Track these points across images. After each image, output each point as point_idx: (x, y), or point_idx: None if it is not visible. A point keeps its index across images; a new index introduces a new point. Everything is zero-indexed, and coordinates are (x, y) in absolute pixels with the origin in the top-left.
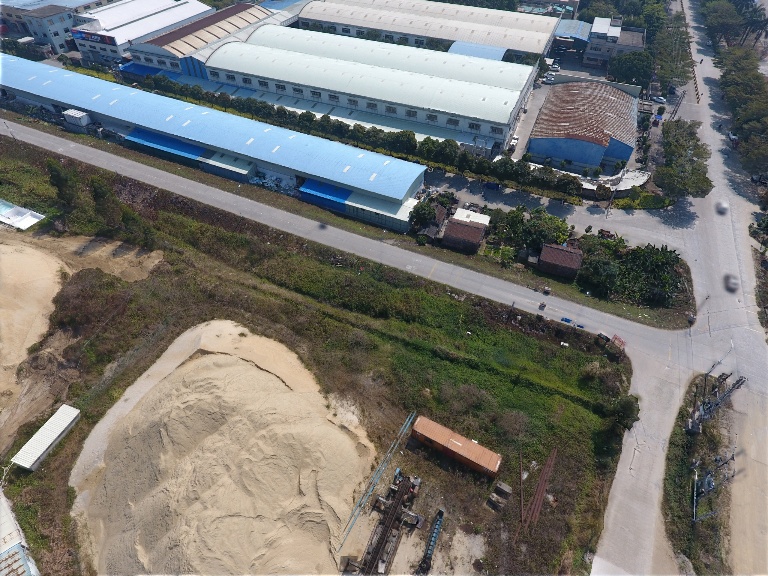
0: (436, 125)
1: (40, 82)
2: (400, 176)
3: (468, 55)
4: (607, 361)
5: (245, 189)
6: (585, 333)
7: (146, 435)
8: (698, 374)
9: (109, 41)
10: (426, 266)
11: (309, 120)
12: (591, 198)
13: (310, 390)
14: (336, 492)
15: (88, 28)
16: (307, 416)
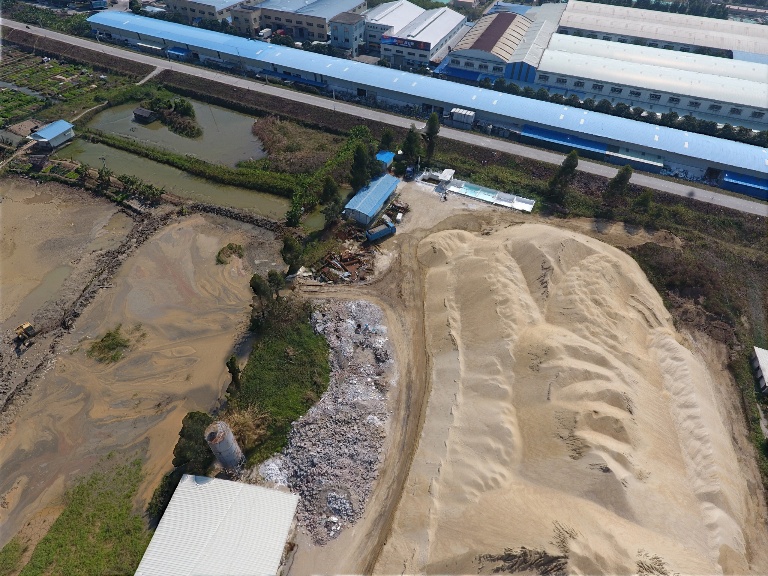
0: None
1: (408, 84)
2: None
3: (763, 63)
4: None
5: (674, 179)
6: None
7: None
8: None
9: (423, 46)
10: None
11: (674, 120)
12: None
13: None
14: None
15: (388, 34)
16: None
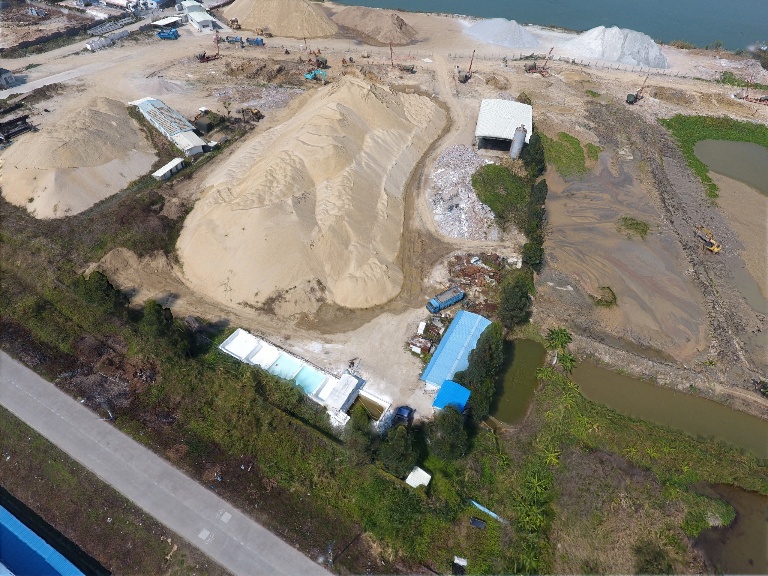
0: None
1: None
2: None
3: None
4: None
5: None
6: None
7: (96, 134)
8: None
9: None
10: None
11: None
12: None
13: (5, 173)
14: None
15: None
16: None
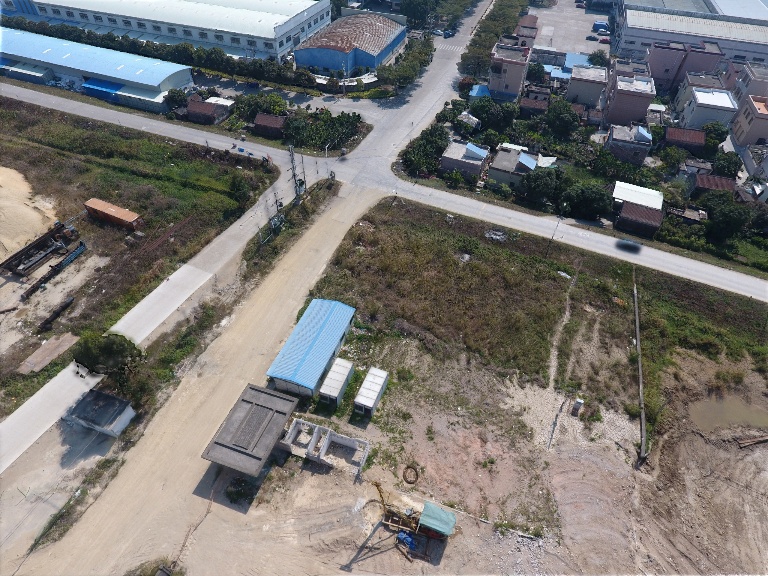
0: (224, 44)
1: None
2: (162, 71)
3: None
4: (261, 173)
5: (36, 86)
6: (256, 159)
7: None
8: (324, 179)
9: None
10: (158, 127)
11: (111, 40)
12: (331, 92)
13: (21, 190)
14: (11, 238)
15: None
16: (3, 197)
